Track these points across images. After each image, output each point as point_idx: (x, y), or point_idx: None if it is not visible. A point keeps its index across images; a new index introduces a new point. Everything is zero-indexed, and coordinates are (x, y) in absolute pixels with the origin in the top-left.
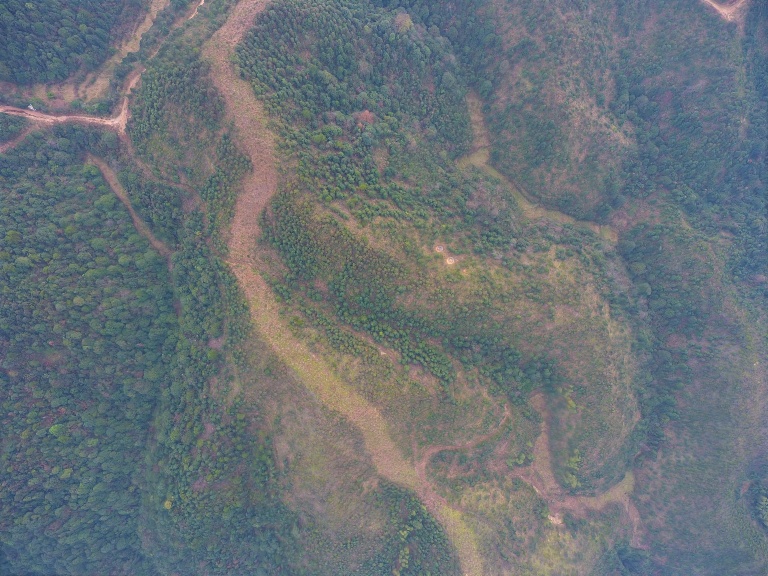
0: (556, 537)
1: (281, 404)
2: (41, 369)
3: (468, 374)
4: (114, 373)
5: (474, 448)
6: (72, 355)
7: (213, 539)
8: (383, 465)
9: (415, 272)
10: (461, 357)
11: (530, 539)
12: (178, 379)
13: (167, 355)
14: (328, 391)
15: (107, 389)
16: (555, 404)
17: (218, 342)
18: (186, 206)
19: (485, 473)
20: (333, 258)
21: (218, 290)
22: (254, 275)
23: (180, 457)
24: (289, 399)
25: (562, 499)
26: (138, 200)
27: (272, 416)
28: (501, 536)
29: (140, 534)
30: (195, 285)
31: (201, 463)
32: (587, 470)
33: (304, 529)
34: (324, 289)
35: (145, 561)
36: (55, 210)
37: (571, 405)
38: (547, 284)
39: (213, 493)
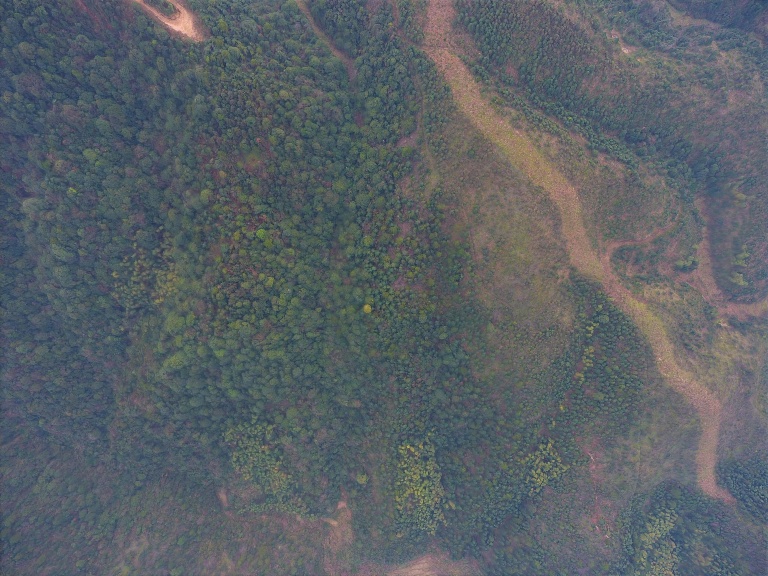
0: (727, 335)
1: (481, 191)
2: (245, 173)
3: (647, 164)
4: (308, 180)
5: (651, 243)
6: (272, 158)
7: (404, 350)
8: (575, 254)
9: (602, 52)
10: (638, 149)
11: (706, 335)
12: (363, 191)
13: (350, 168)
14: (533, 166)
15: (300, 199)
16: (718, 205)
17: (410, 140)
18: (370, 5)
19: (658, 274)
20: (531, 33)
21: (412, 82)
22: (452, 57)
23: (378, 259)
24: (491, 182)
25: (724, 305)
26: (325, 0)
27: (469, 208)
28: (682, 329)
29: (324, 360)
30: (384, 84)
31: (401, 260)
32: (753, 268)
33: (500, 324)
34: (514, 75)
35: (324, 393)
36: (251, 8)
37: (740, 198)
38: (719, 70)
39: (412, 292)
